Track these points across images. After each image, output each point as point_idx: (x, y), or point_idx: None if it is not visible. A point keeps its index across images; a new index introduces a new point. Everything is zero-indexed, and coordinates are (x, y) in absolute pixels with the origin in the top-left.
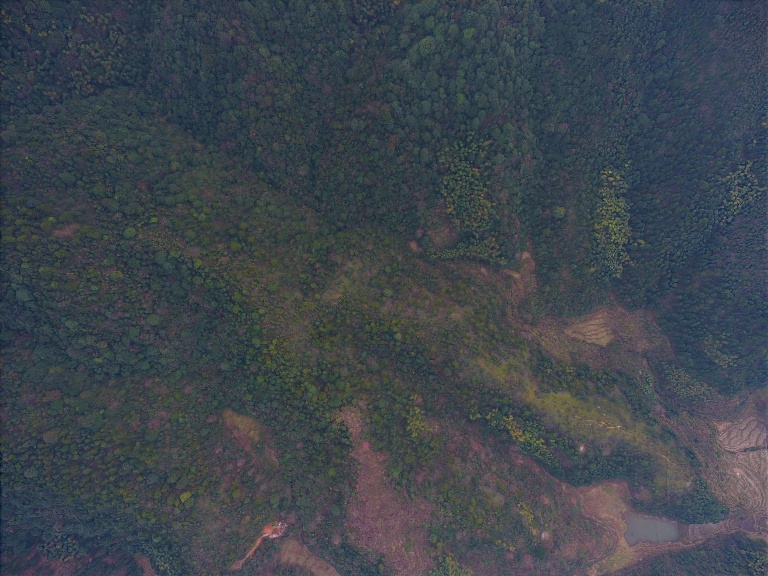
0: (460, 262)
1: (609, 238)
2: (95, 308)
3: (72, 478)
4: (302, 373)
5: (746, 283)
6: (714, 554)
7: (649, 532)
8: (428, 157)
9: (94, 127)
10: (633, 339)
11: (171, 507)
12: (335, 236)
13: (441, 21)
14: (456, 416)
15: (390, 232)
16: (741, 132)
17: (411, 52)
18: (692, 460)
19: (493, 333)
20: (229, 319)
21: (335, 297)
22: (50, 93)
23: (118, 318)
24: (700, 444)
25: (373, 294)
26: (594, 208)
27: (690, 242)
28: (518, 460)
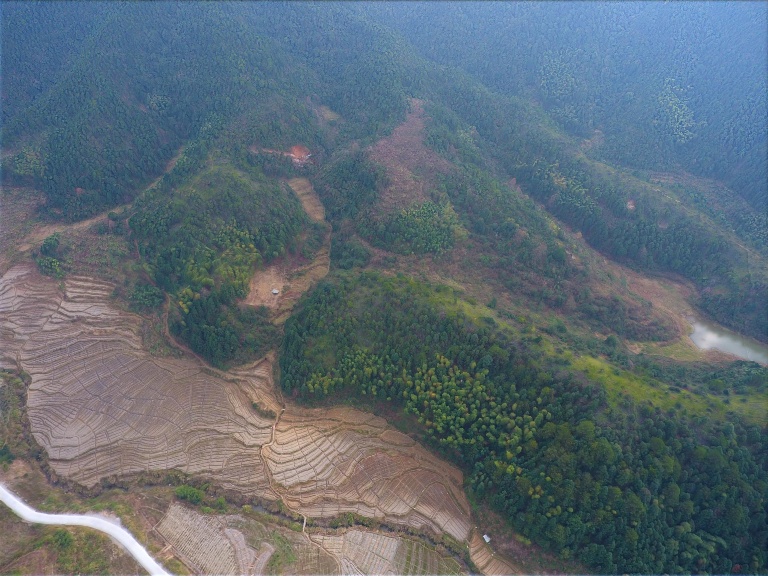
0: None
1: None
2: None
3: None
4: None
5: None
6: None
7: (731, 346)
8: None
9: None
10: None
11: None
12: None
13: None
14: (503, 173)
15: None
16: None
17: (542, 1)
18: None
19: None
20: None
21: None
22: None
23: None
24: None
25: None
26: None
27: (752, 124)
28: None
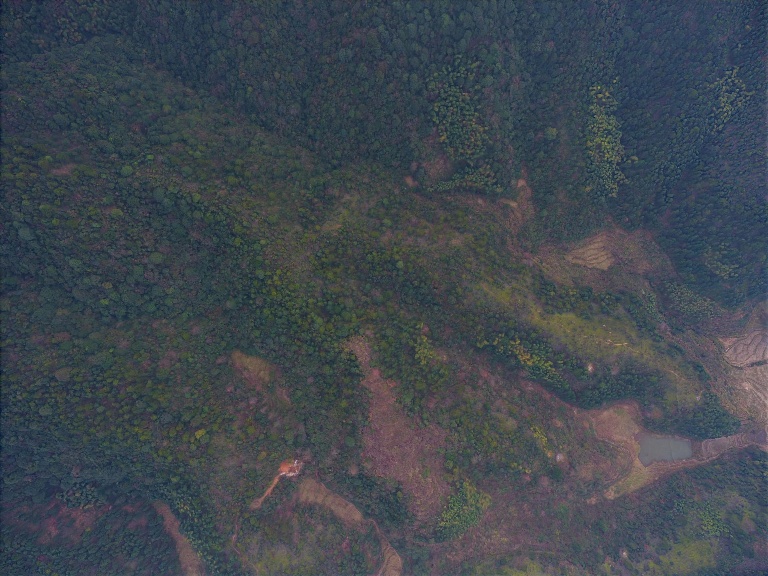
0: (457, 194)
1: (602, 156)
2: (98, 246)
3: (87, 417)
4: (308, 304)
5: (741, 189)
6: (729, 467)
7: (663, 451)
8: (417, 83)
9: (84, 71)
10: (633, 260)
11: (187, 445)
12: (331, 173)
13: None
14: (463, 346)
15: (385, 168)
16: (725, 37)
17: None
18: (700, 373)
19: (494, 259)
20: (231, 254)
21: (335, 228)
22: (38, 41)
23: (121, 256)
24: (707, 358)
25: (373, 224)
26: (585, 126)
27: (683, 154)
28: (528, 387)
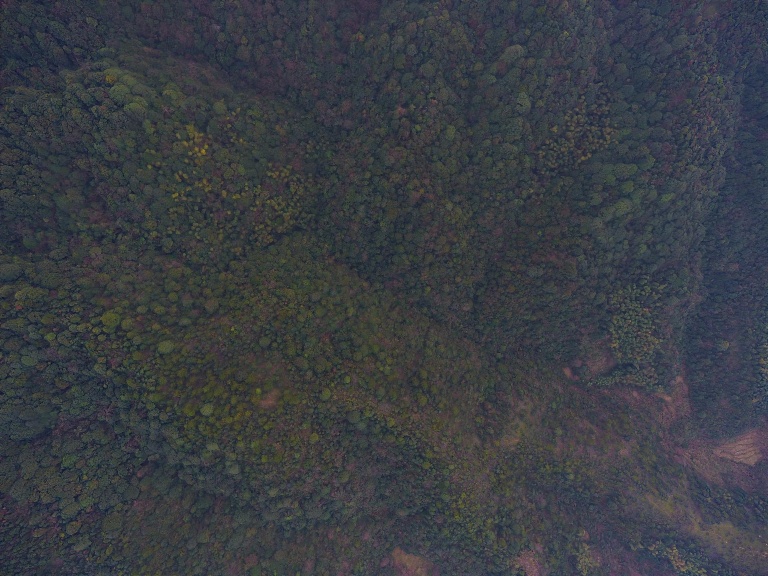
0: (613, 387)
1: None
2: (296, 474)
3: None
4: (484, 522)
5: None
6: None
7: None
8: None
9: (282, 284)
10: None
11: None
12: (497, 369)
13: (642, 187)
14: (613, 543)
15: (547, 361)
16: None
17: (606, 213)
18: None
19: (655, 464)
20: (414, 471)
21: (513, 442)
22: (237, 249)
23: (313, 480)
24: None
25: (547, 436)
26: (760, 343)
27: None
28: None
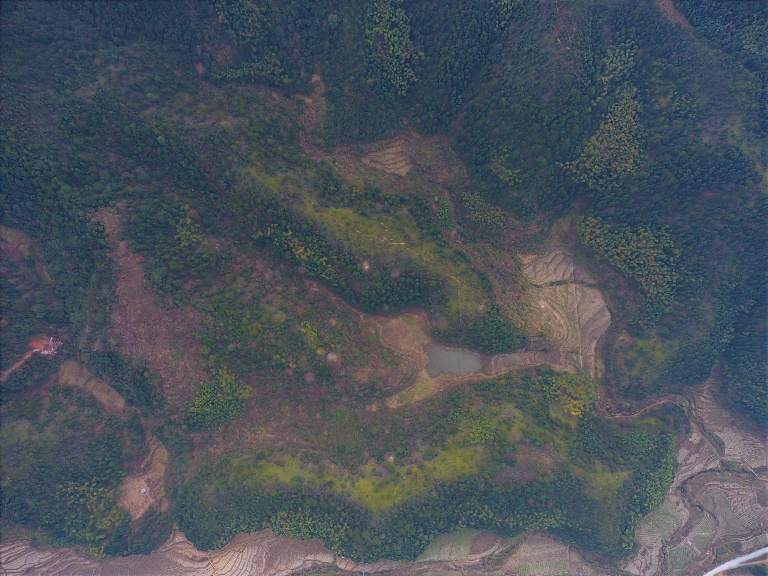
0: (248, 85)
1: (387, 49)
2: None
3: None
4: (50, 168)
5: (519, 88)
6: (513, 382)
7: (451, 364)
8: None
9: None
10: (431, 167)
11: None
12: None
13: None
14: (243, 239)
15: (172, 51)
16: None
17: None
18: (483, 281)
19: (272, 148)
20: None
21: (88, 94)
22: None
23: None
24: (495, 269)
25: (133, 95)
26: (365, 13)
27: (467, 51)
28: (313, 288)
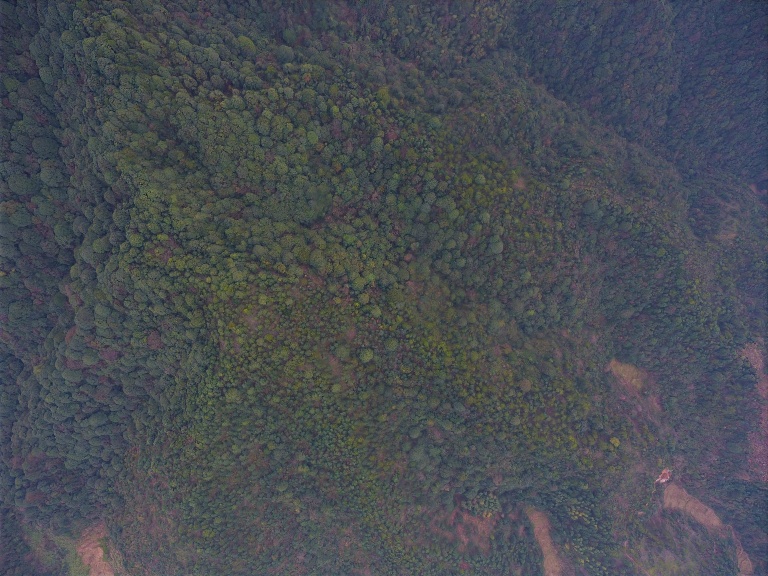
0: None
1: None
2: (547, 258)
3: None
4: (713, 312)
5: None
6: None
7: None
8: None
9: None
10: None
11: (603, 453)
12: (693, 183)
13: None
14: None
15: None
16: None
17: None
18: None
19: None
20: (645, 264)
21: (731, 237)
22: (459, 57)
23: (559, 268)
24: None
25: (758, 233)
26: None
27: None
28: None
